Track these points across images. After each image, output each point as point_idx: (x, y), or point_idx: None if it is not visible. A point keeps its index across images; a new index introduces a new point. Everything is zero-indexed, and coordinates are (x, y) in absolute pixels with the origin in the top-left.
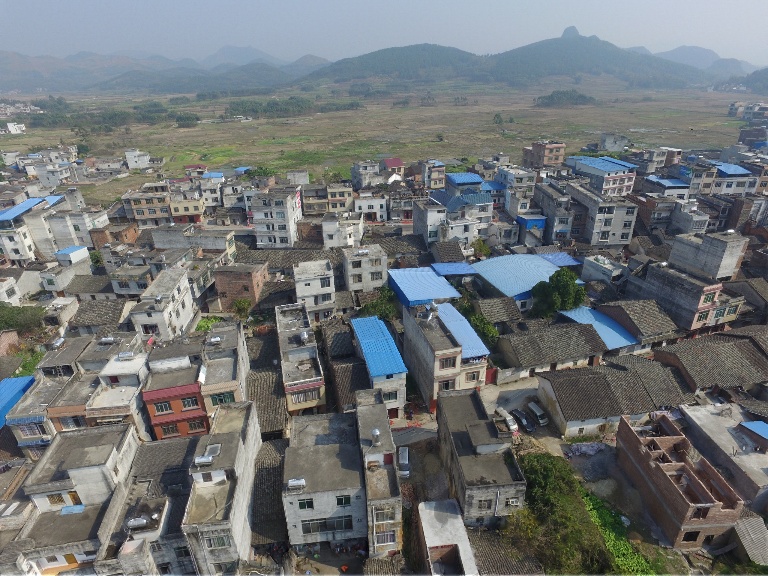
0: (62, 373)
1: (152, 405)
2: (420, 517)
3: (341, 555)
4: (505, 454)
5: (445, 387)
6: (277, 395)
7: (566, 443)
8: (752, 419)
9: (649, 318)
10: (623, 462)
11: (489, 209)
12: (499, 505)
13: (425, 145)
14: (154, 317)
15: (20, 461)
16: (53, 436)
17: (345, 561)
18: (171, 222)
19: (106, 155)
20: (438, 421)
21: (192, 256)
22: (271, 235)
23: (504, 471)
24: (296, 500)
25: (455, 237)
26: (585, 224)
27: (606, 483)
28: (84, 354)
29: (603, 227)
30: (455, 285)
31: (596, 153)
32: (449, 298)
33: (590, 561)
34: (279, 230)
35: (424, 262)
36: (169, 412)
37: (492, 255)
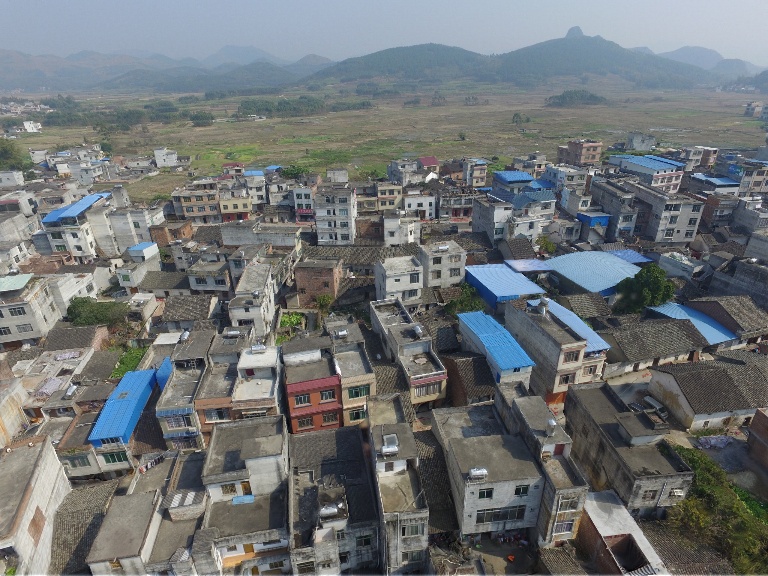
0: (195, 366)
1: (293, 397)
2: (584, 507)
3: (504, 545)
4: (659, 445)
5: (565, 381)
6: (400, 388)
7: (692, 436)
8: None
9: (747, 313)
10: (759, 454)
11: (551, 206)
12: (663, 495)
13: (448, 144)
14: (251, 312)
15: (173, 452)
16: (198, 428)
17: (509, 551)
18: (219, 220)
19: (129, 153)
20: (568, 414)
21: (265, 252)
22: (333, 232)
23: (664, 462)
24: (478, 489)
25: (520, 234)
26: (648, 221)
27: (747, 475)
28: (214, 347)
29: (668, 224)
30: (534, 281)
31: (624, 152)
32: (534, 294)
33: (759, 551)
34: (341, 227)
35: (493, 259)
36: (307, 404)
37: (554, 252)
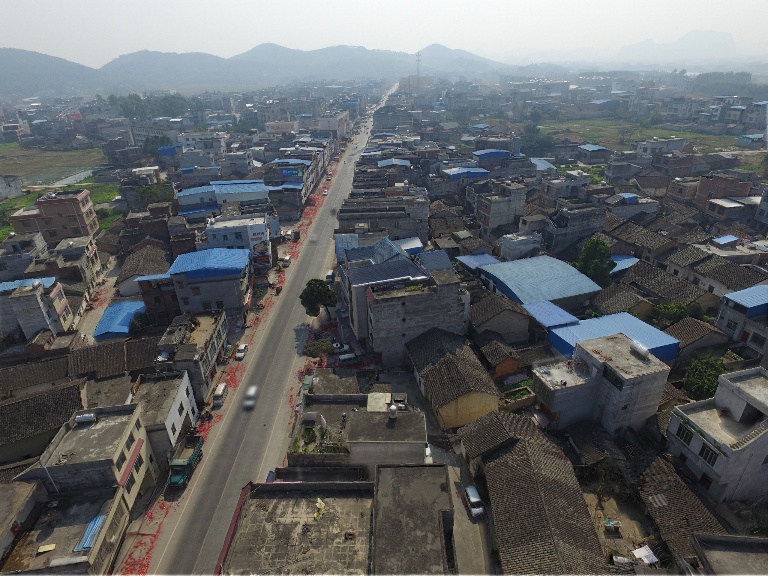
0: None
1: None
2: None
3: None
4: None
5: None
6: None
7: None
8: (705, 243)
9: None
10: None
11: None
12: None
13: None
14: None
15: None
16: None
17: None
18: None
19: None
20: None
21: None
22: None
23: None
24: None
25: None
26: None
27: None
28: None
29: None
30: None
31: None
32: None
33: None
34: None
35: None
36: None
37: None
